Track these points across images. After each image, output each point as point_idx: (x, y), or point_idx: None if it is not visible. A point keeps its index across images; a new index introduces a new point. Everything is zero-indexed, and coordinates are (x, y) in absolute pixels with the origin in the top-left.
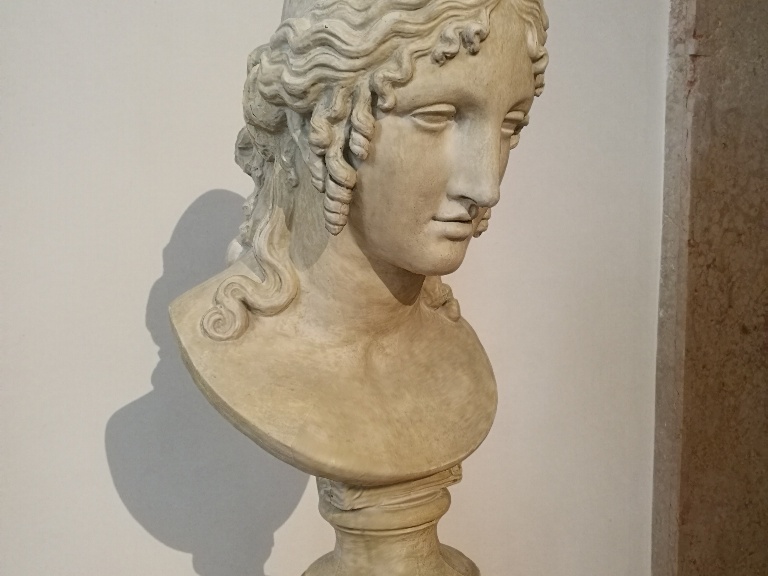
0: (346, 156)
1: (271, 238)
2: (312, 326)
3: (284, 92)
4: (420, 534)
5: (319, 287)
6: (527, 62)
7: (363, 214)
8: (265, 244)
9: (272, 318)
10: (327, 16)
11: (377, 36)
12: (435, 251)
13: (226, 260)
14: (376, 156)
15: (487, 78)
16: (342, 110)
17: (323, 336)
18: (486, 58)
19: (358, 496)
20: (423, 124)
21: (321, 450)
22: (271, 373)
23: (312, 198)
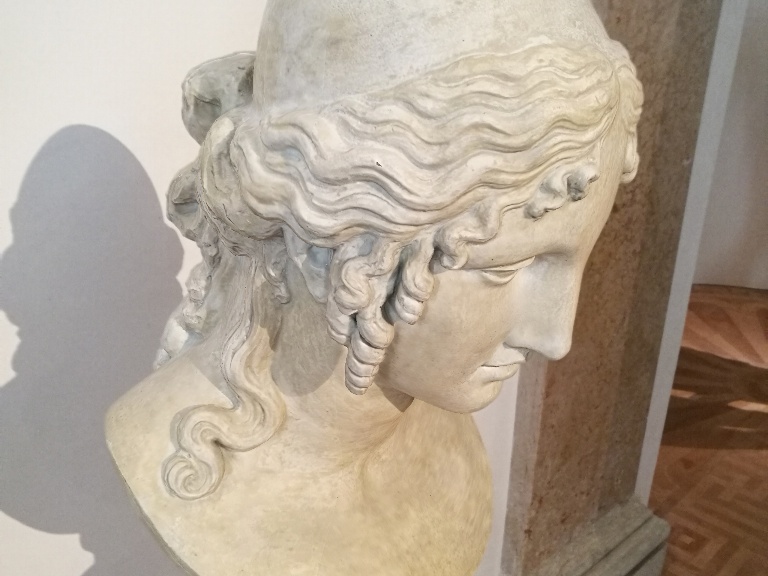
0: (384, 311)
1: (249, 361)
2: (301, 454)
3: (294, 221)
4: None
5: (313, 416)
6: None
7: (392, 361)
8: (241, 369)
9: (251, 451)
10: (373, 137)
11: (458, 188)
12: (477, 396)
13: (165, 347)
14: (427, 314)
15: (585, 223)
16: (390, 267)
17: (315, 463)
18: (588, 200)
19: None
20: (495, 280)
21: None
22: (262, 531)
23: (312, 324)
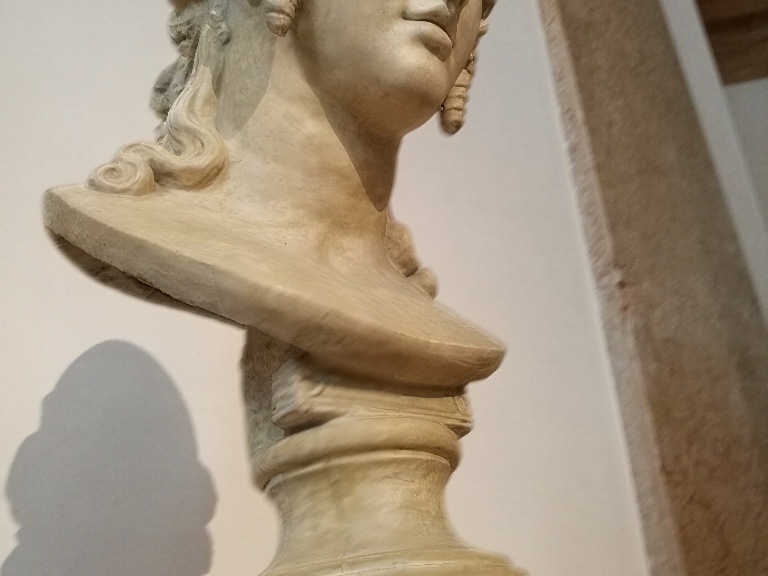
0: None
1: (192, 104)
2: (244, 203)
3: None
4: (421, 473)
5: (255, 149)
6: None
7: (314, 20)
8: (184, 110)
9: (188, 193)
10: None
11: None
12: (409, 56)
13: None
14: None
15: None
16: None
17: (259, 214)
18: None
19: (318, 392)
20: None
21: (260, 275)
22: (184, 224)
23: (248, 42)
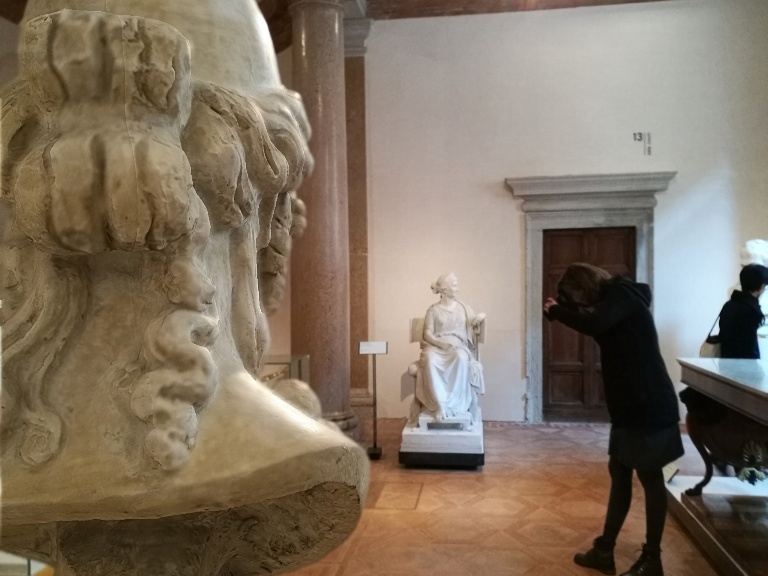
0: None
1: None
2: None
3: None
4: None
5: None
6: None
7: None
8: None
9: None
10: None
11: None
12: None
13: None
14: None
15: None
16: None
17: None
18: None
19: None
20: None
21: None
22: None
23: None
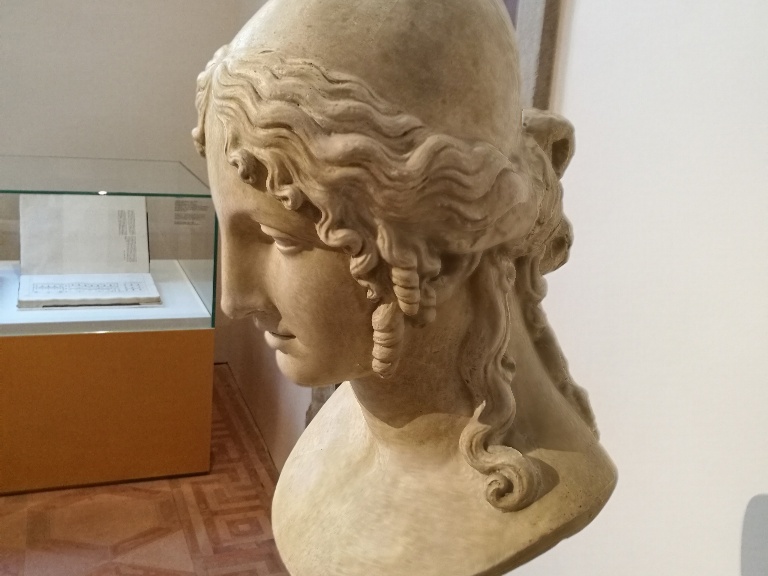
0: None
1: None
2: None
3: None
4: None
5: None
6: (232, 168)
7: None
8: None
9: None
10: None
11: None
12: None
13: None
14: None
15: None
16: None
17: None
18: None
19: None
20: None
21: None
22: (340, 412)
23: None
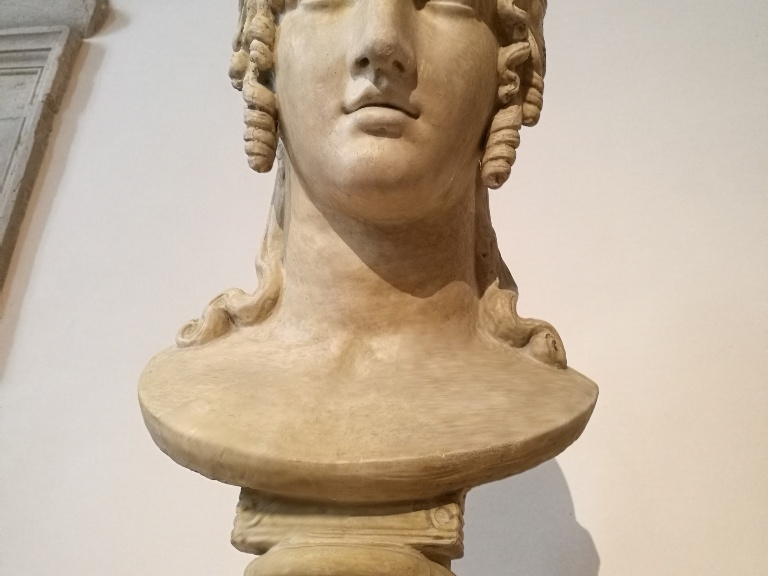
0: (263, 80)
1: (266, 242)
2: (286, 327)
3: None
4: None
5: (291, 274)
6: None
7: (291, 145)
8: (260, 250)
9: (253, 328)
10: None
11: None
12: (351, 151)
13: None
14: (278, 61)
15: None
16: None
17: (294, 336)
18: None
19: (256, 522)
20: (310, 2)
21: (188, 420)
22: (209, 367)
23: (285, 174)
